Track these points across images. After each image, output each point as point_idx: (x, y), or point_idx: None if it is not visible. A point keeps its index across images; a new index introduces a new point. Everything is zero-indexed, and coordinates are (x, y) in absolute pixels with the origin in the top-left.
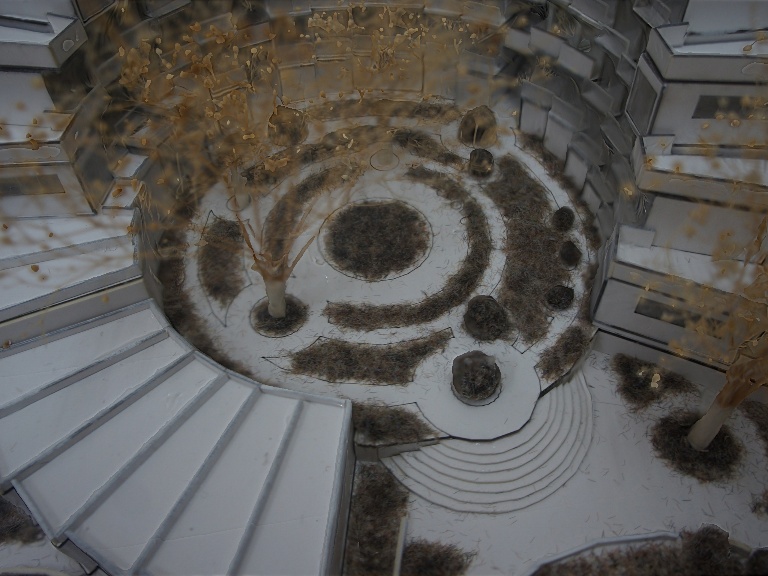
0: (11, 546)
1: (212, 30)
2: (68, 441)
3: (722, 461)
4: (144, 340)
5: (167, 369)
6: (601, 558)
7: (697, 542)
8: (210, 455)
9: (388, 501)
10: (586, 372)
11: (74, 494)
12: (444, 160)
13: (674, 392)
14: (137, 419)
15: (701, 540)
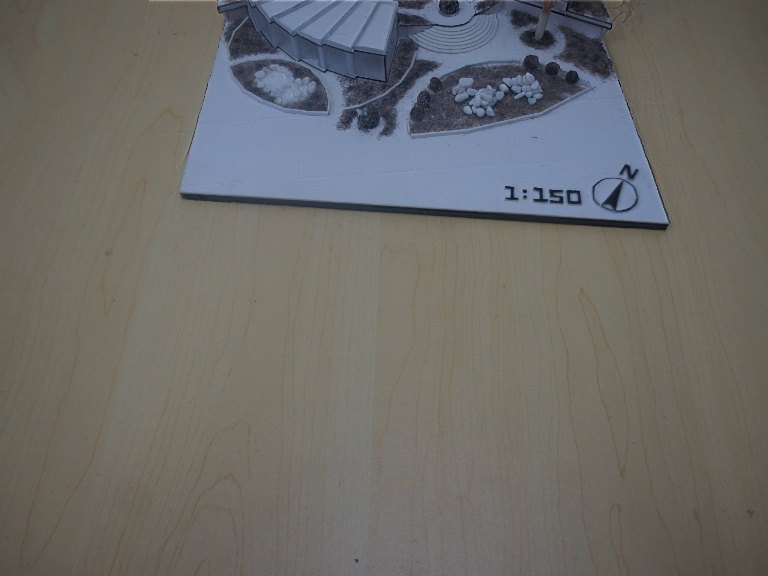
0: (266, 54)
1: None
2: (292, 9)
3: (546, 43)
4: None
5: None
6: (490, 67)
7: (525, 58)
8: (346, 14)
9: (410, 48)
10: (498, 16)
11: (297, 24)
12: None
13: (534, 24)
14: (316, 6)
15: (527, 57)
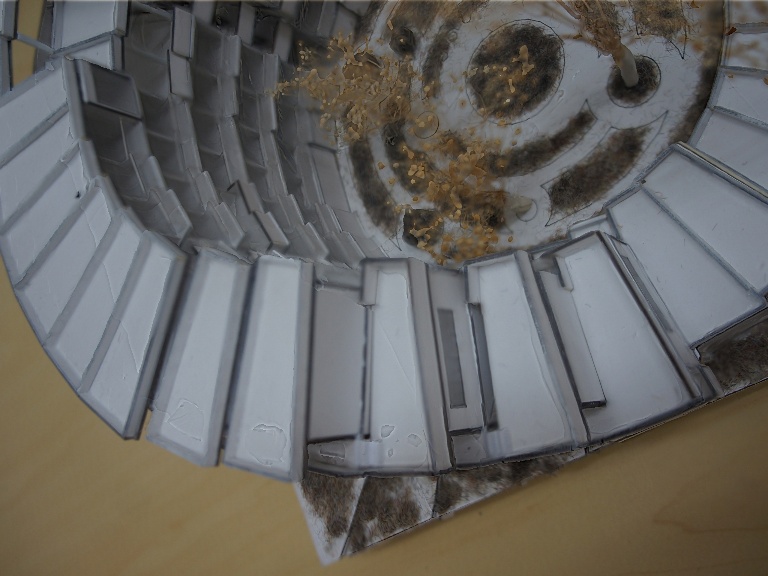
0: None
1: (414, 171)
2: None
3: None
4: (734, 114)
5: (753, 71)
6: None
7: None
8: None
9: None
10: None
11: None
12: (408, 77)
13: None
14: None
15: None
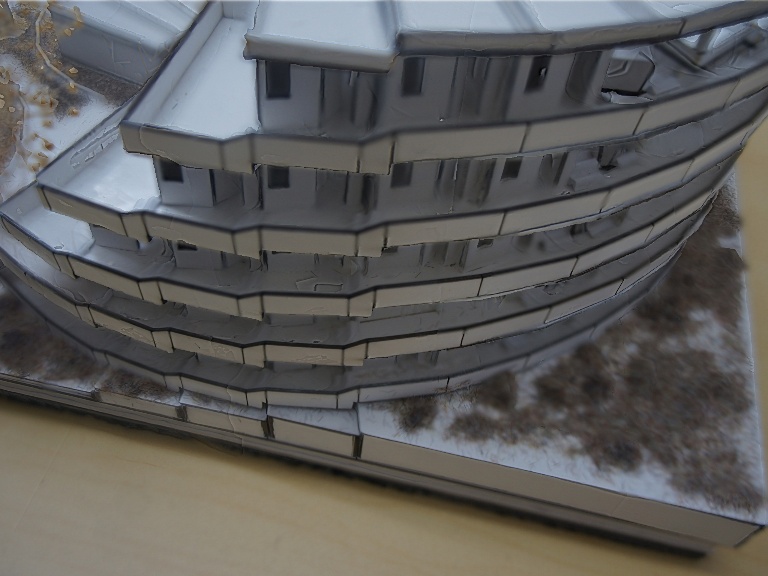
0: None
1: None
2: None
3: None
4: None
5: None
6: (3, 169)
7: None
8: None
9: (122, 97)
10: None
11: None
12: None
13: None
14: None
15: None
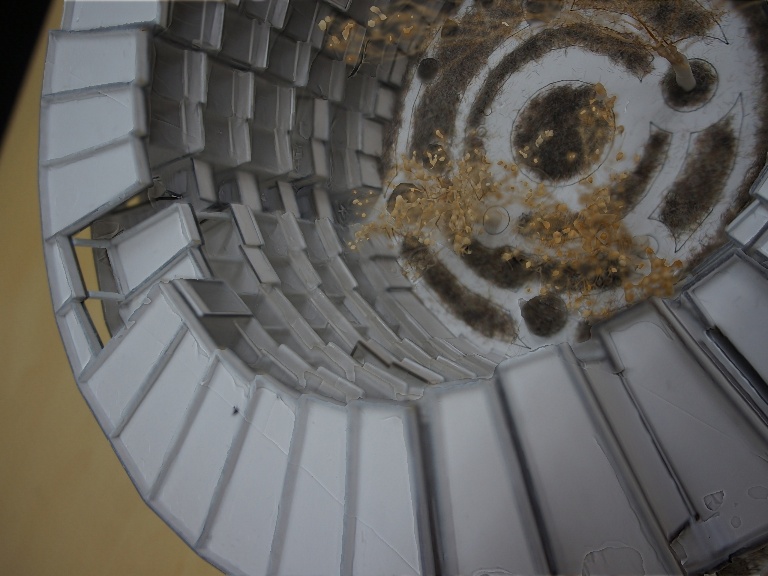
0: None
1: None
2: None
3: None
4: None
5: None
6: None
7: None
8: None
9: None
10: None
11: None
12: None
13: None
14: None
15: None
